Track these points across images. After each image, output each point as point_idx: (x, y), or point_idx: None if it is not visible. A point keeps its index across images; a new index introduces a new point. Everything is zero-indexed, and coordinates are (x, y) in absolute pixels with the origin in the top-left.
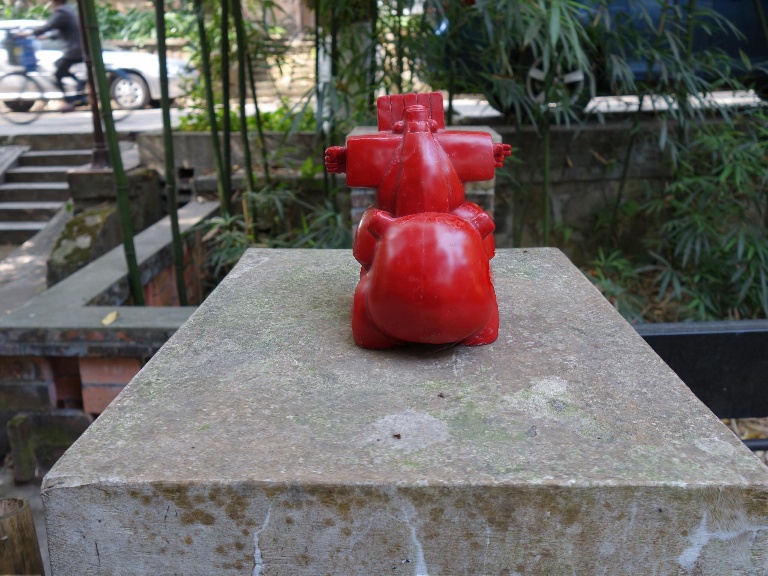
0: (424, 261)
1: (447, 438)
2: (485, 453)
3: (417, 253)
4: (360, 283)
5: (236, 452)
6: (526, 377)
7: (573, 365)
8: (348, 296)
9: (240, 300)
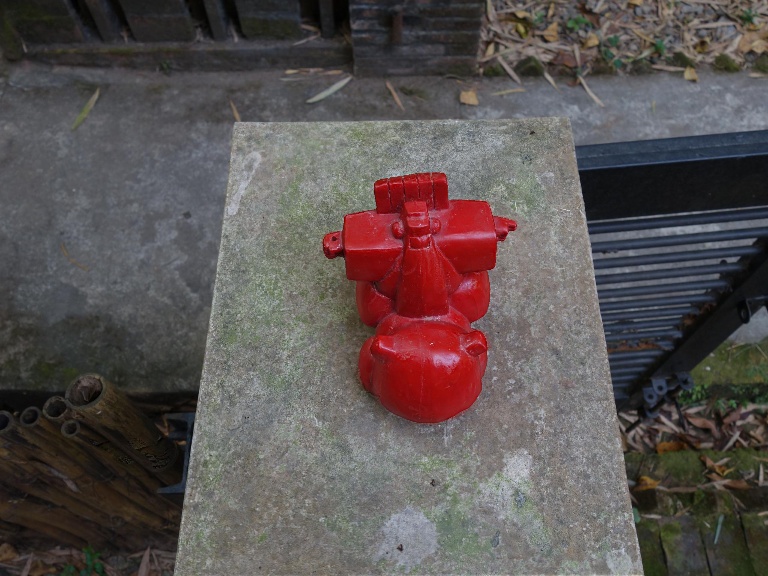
0: (422, 400)
1: (435, 549)
2: (460, 571)
3: (416, 393)
4: (365, 359)
5: (291, 573)
6: (501, 452)
7: (541, 428)
8: None
9: (249, 277)
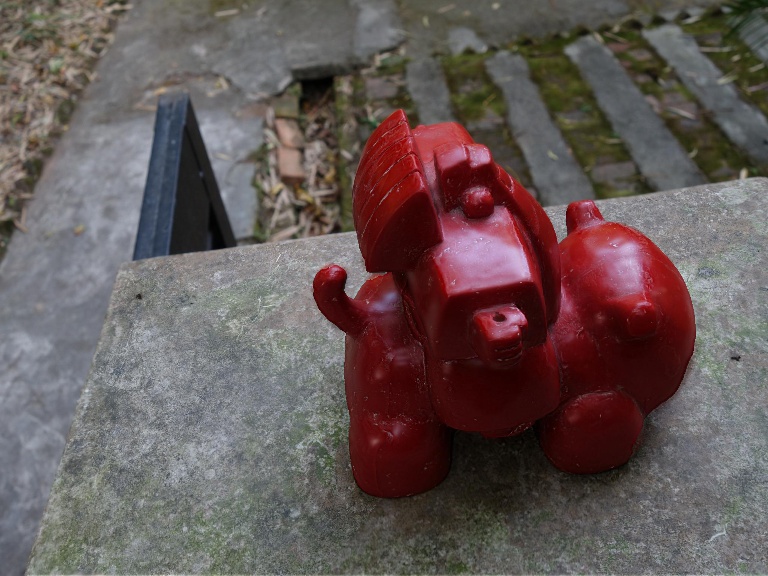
0: None
1: None
2: None
3: (683, 287)
4: (617, 409)
5: None
6: None
7: None
8: (391, 522)
9: None
